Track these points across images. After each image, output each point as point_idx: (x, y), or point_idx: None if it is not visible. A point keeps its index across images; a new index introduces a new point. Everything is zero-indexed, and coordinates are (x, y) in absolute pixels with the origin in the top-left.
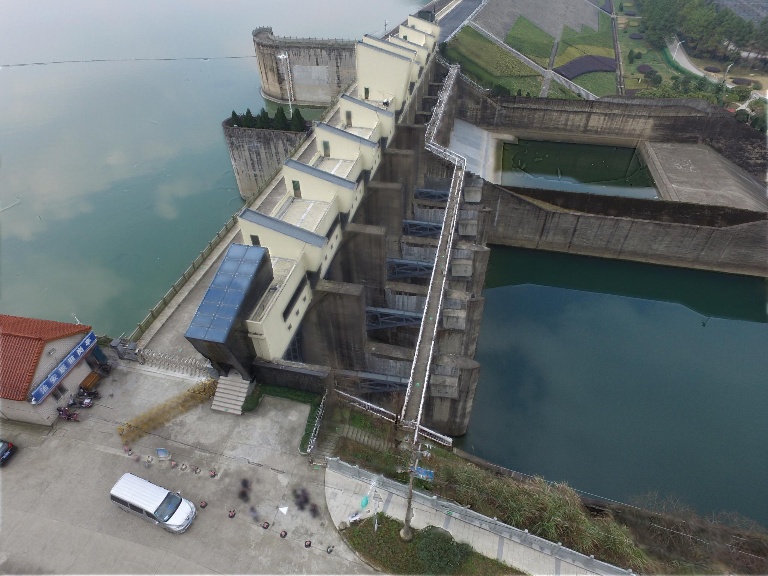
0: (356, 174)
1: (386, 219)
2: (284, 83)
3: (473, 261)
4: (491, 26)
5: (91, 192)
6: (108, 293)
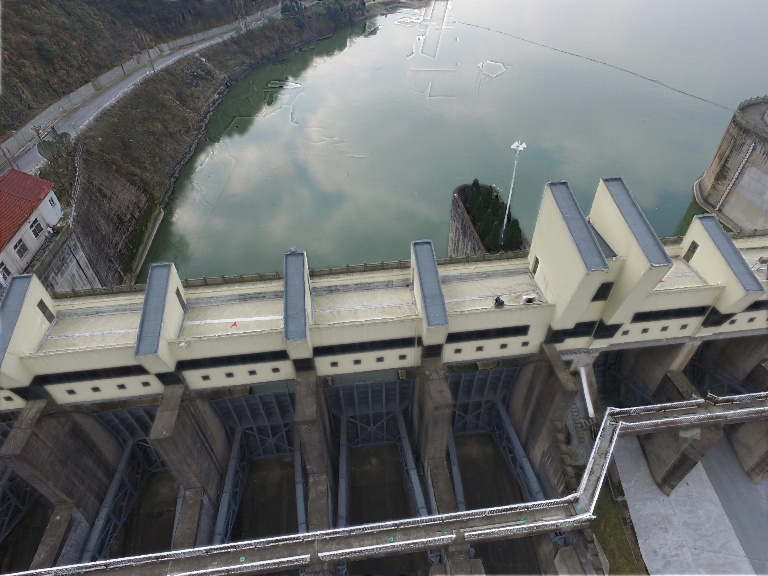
0: (255, 346)
1: None
2: (722, 182)
3: None
4: None
5: (399, 178)
6: (265, 258)
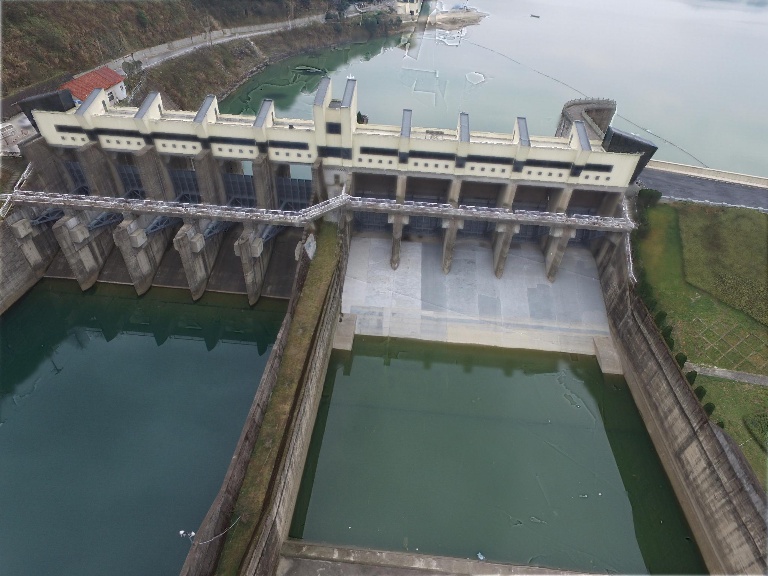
0: (184, 130)
1: None
2: None
3: None
4: None
5: None
6: None
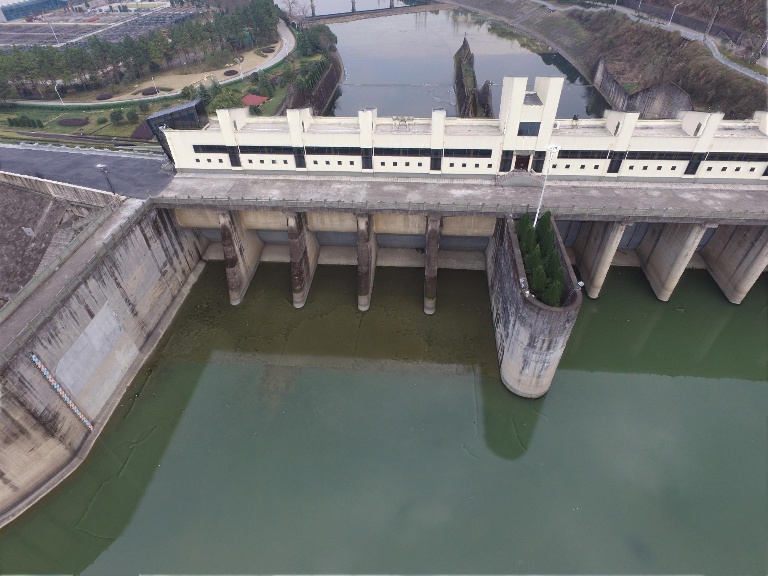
0: None
1: None
2: (59, 422)
3: None
4: None
5: None
6: None
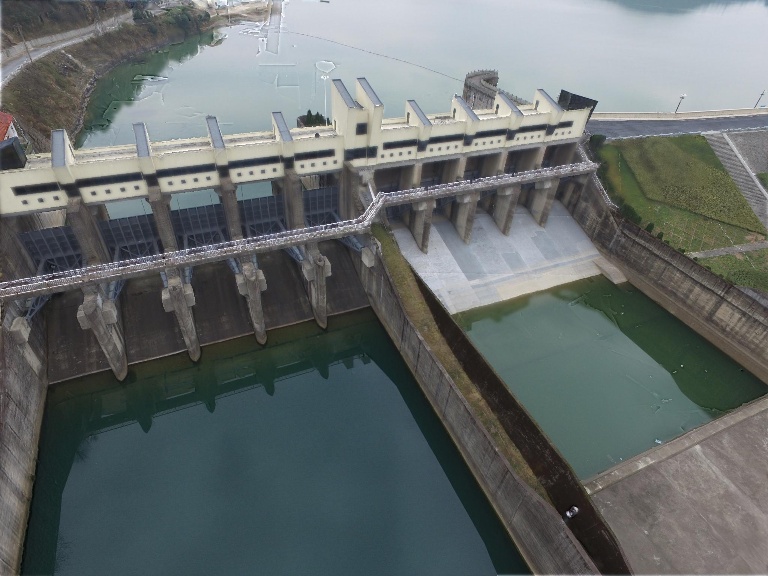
0: (197, 161)
1: (227, 213)
2: None
3: (246, 284)
4: (765, 151)
5: None
6: None
